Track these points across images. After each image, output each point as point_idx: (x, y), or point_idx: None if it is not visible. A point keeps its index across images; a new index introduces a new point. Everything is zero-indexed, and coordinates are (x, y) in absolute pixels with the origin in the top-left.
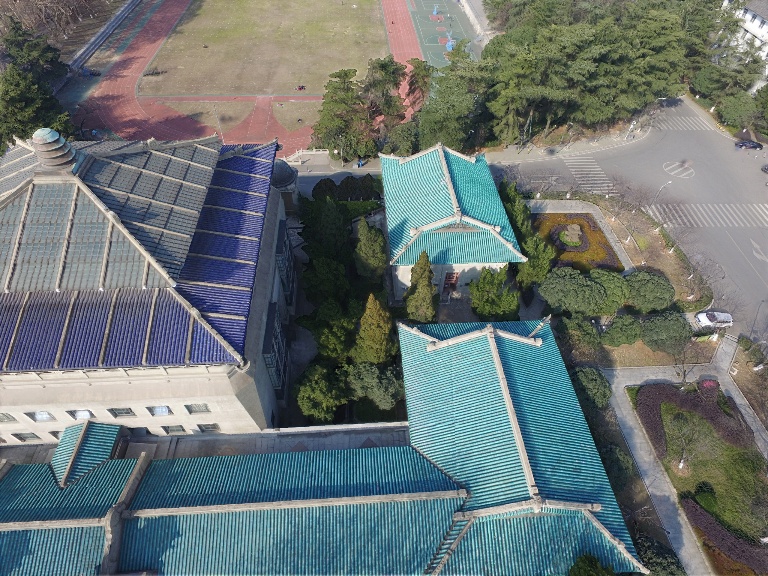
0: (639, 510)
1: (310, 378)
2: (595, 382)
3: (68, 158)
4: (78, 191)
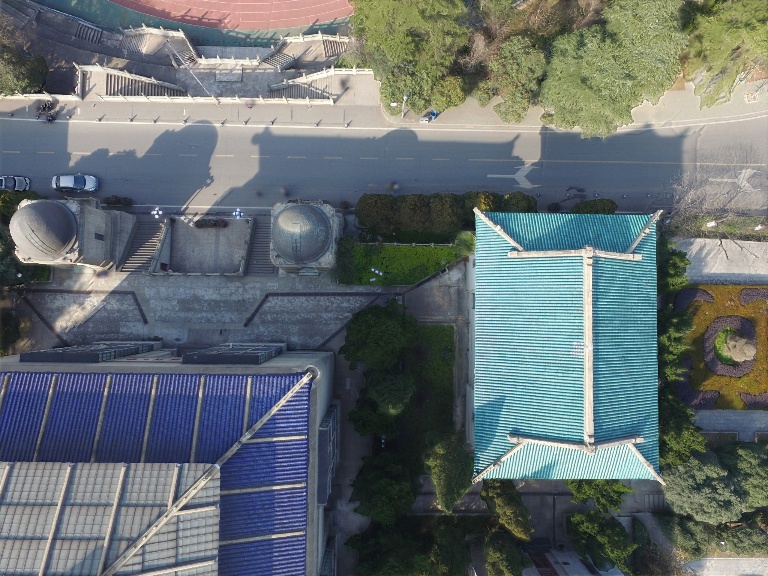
0: None
1: None
2: None
3: None
4: None
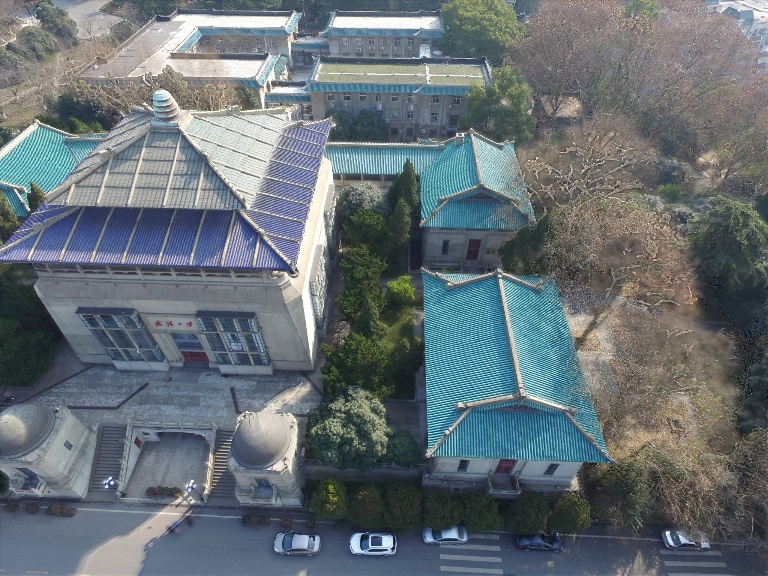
0: None
1: None
2: None
3: None
4: None
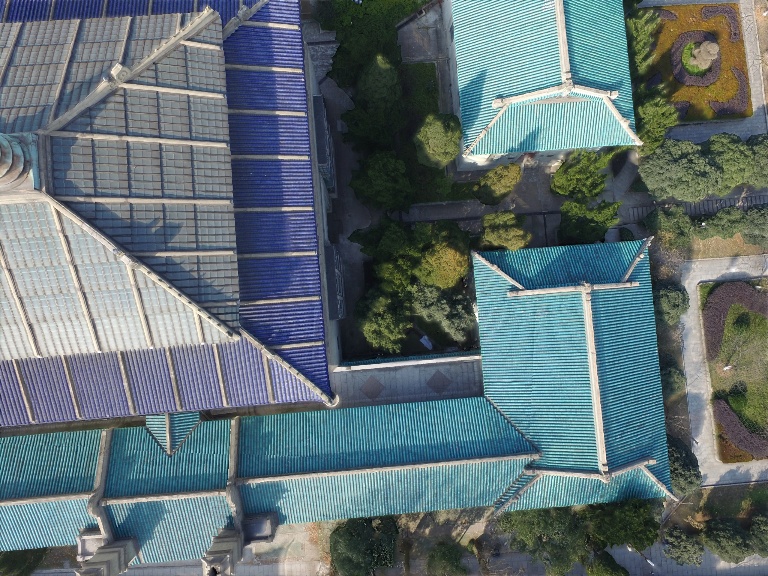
0: (676, 417)
1: (375, 311)
2: (677, 309)
3: (18, 169)
4: (58, 215)
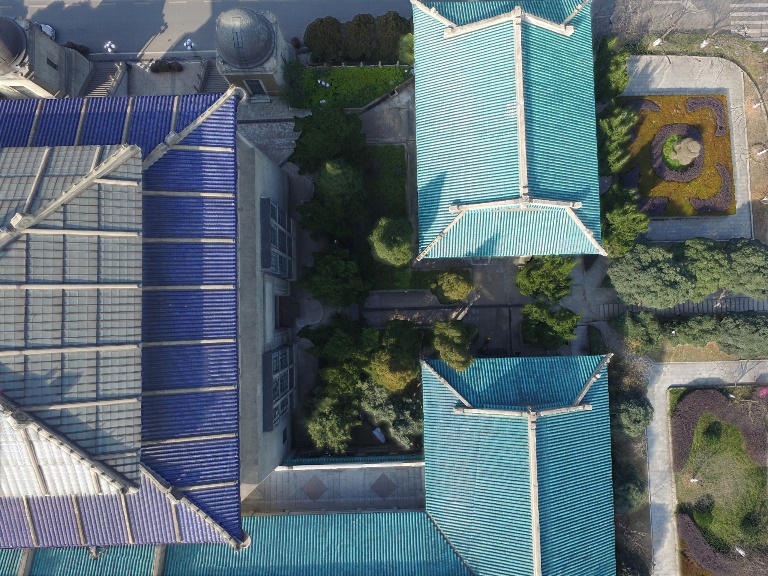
0: (635, 532)
1: (320, 411)
2: (638, 425)
3: None
4: None
